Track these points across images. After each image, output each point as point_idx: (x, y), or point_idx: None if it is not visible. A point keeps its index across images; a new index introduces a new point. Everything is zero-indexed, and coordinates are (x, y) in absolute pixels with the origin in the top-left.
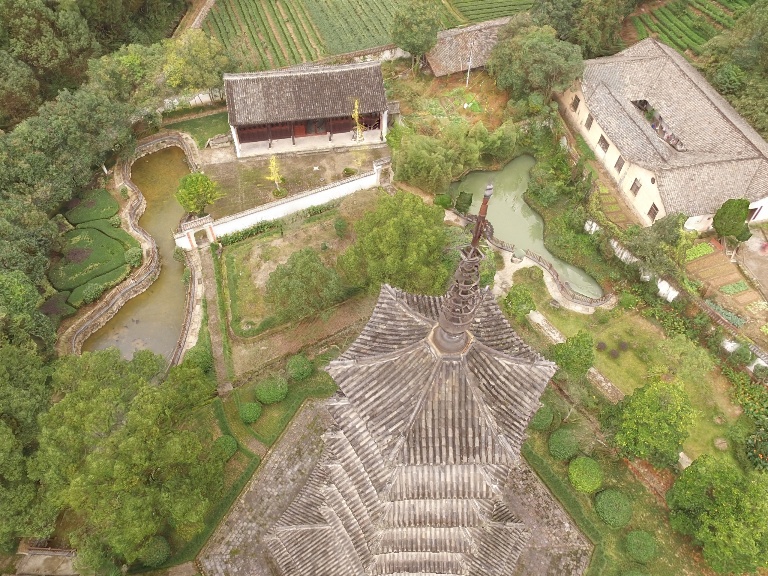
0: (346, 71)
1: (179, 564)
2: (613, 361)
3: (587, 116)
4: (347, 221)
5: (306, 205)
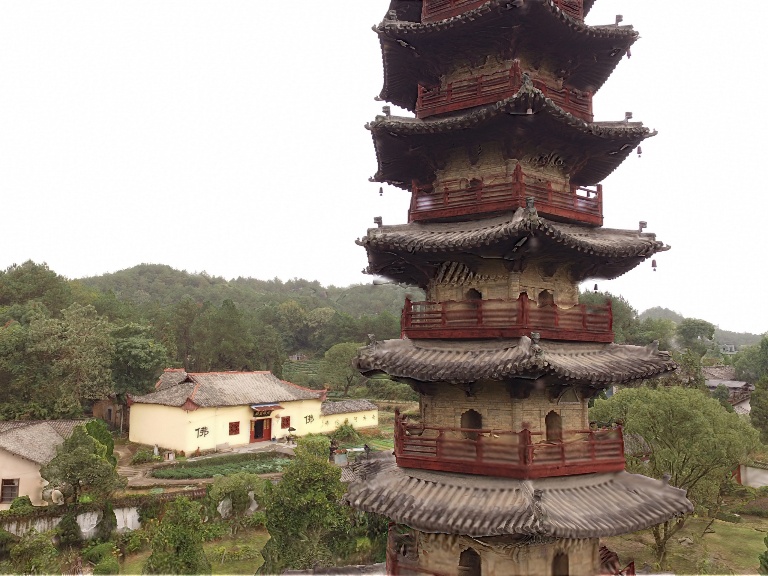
0: None
1: None
2: None
3: None
4: None
5: None
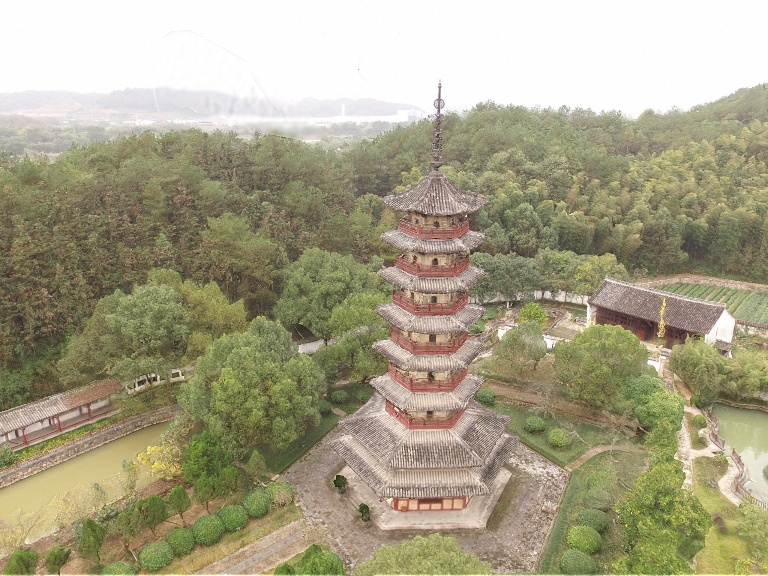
0: (693, 302)
1: (341, 409)
2: (717, 533)
3: None
4: None
5: None
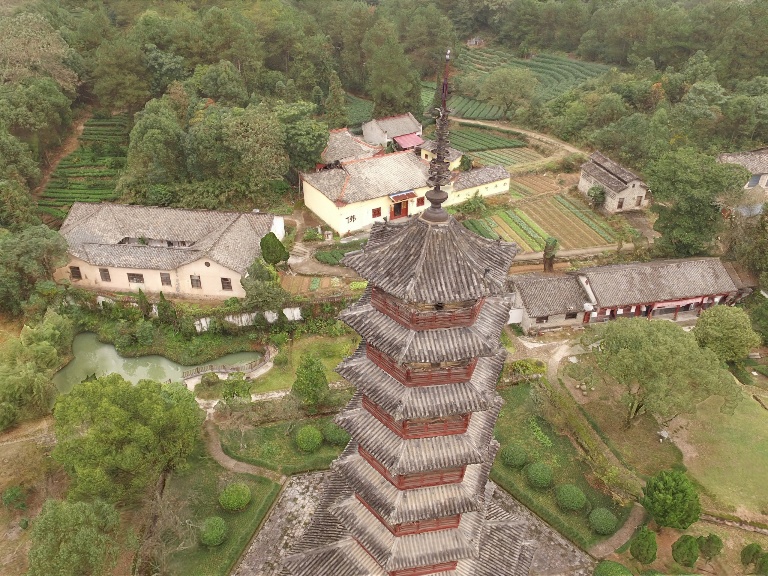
0: None
1: None
2: None
3: (99, 272)
4: (16, 485)
5: None
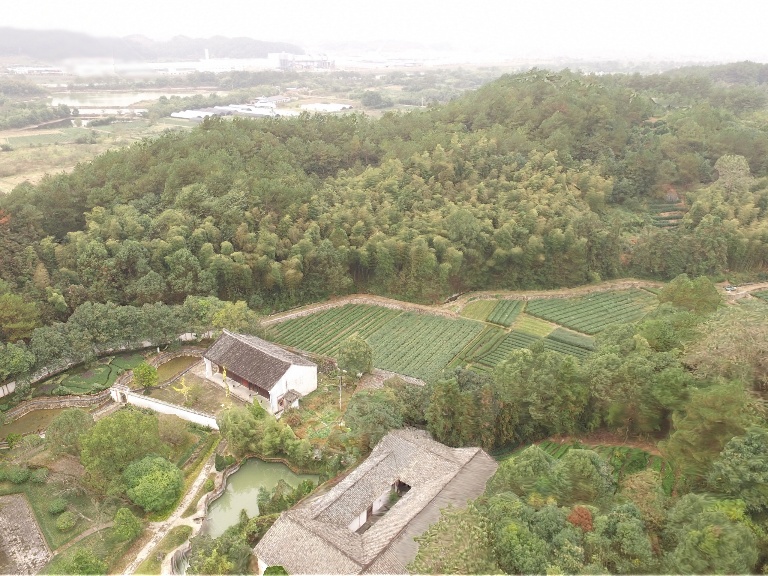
0: (274, 357)
1: None
2: None
3: None
4: None
5: (176, 414)
